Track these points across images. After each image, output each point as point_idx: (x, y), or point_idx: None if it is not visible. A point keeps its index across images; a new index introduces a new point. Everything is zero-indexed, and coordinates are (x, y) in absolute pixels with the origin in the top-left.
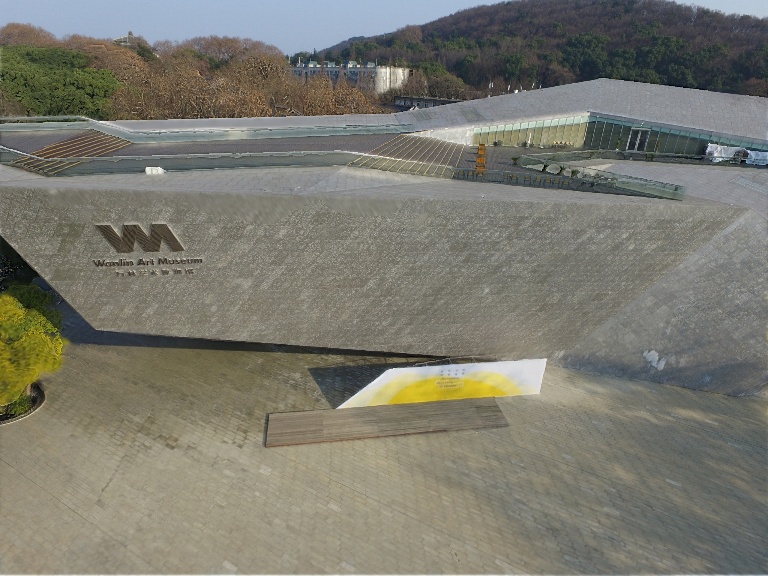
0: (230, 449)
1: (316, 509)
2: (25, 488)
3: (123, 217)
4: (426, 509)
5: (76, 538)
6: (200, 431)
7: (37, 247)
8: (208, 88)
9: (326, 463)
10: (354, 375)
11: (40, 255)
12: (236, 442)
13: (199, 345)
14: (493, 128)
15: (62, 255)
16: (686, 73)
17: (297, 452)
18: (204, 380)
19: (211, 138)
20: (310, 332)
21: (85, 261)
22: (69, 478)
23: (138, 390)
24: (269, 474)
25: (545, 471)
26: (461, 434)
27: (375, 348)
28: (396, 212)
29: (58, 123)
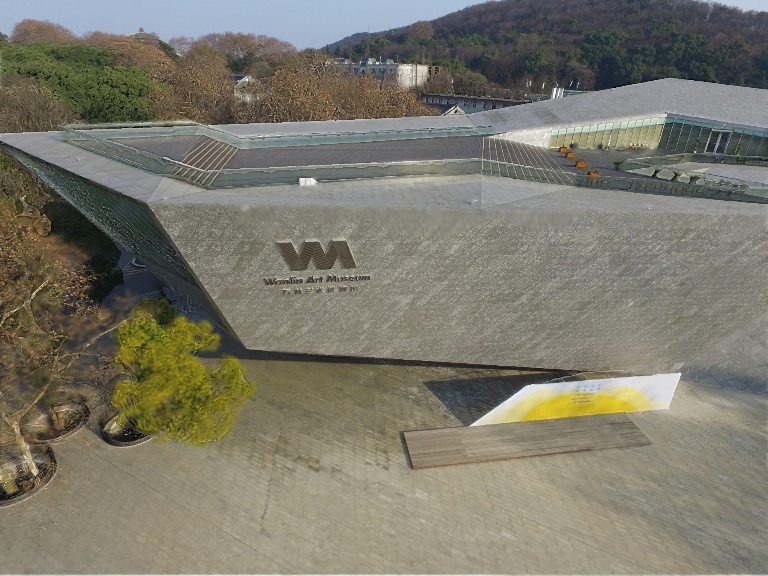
0: (377, 471)
1: (490, 537)
2: (181, 516)
3: (305, 234)
4: (603, 537)
5: (254, 572)
6: (339, 451)
7: (213, 266)
8: (283, 89)
9: (481, 486)
10: (473, 389)
11: (214, 274)
12: (380, 463)
13: (303, 357)
14: (570, 130)
15: (235, 274)
16: (708, 70)
17: (447, 474)
18: (322, 395)
19: (308, 143)
20: (451, 348)
21: (256, 279)
22: (223, 505)
23: (259, 407)
24: (427, 499)
25: (708, 494)
26: (607, 453)
27: (507, 363)
28: (570, 226)
29: (163, 128)
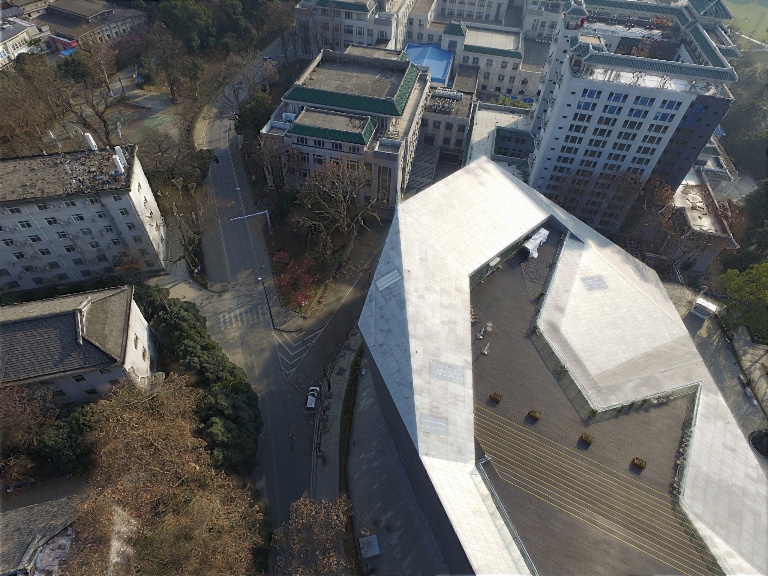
0: None
1: None
2: None
3: None
4: None
5: None
6: None
7: None
8: None
9: None
10: None
11: None
12: None
13: None
14: None
15: None
16: None
17: None
18: None
19: None
20: None
21: None
22: None
23: None
24: None
25: None
26: None
27: None
28: None
29: None
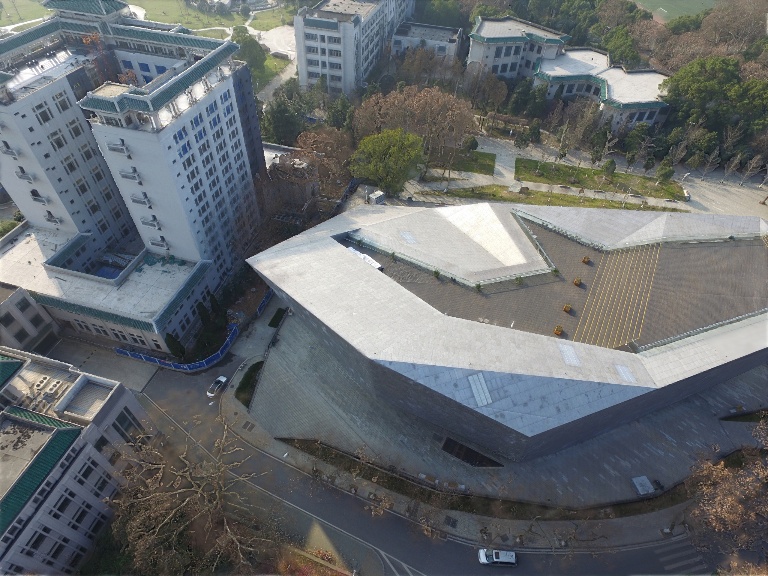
0: None
1: None
2: None
3: None
4: None
5: None
6: None
7: None
8: None
9: None
10: None
11: None
12: None
13: None
14: None
15: None
16: None
17: None
18: None
19: None
20: None
21: None
22: None
23: None
24: None
25: None
26: None
27: None
28: None
29: None
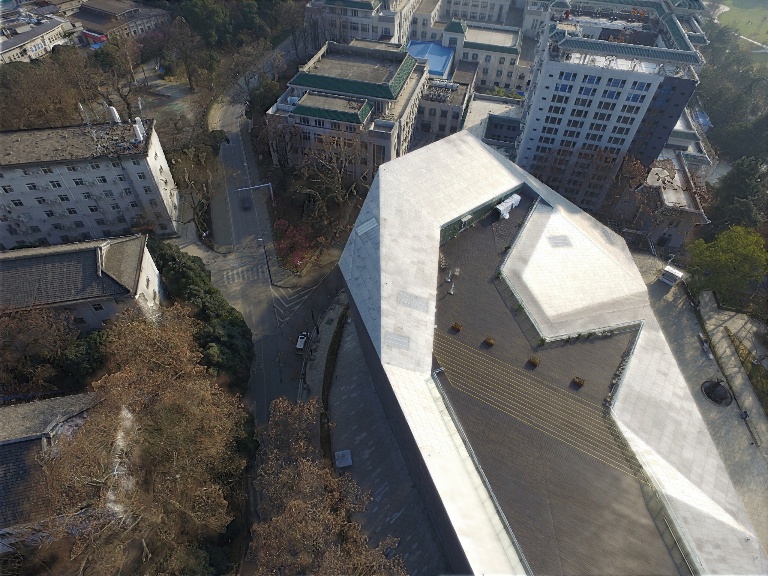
0: None
1: None
2: None
3: None
4: None
5: None
6: None
7: None
8: None
9: None
10: None
11: None
12: None
13: None
14: None
15: None
16: None
17: None
18: None
19: None
20: None
21: None
22: None
23: None
24: None
25: None
26: None
27: None
28: None
29: None
